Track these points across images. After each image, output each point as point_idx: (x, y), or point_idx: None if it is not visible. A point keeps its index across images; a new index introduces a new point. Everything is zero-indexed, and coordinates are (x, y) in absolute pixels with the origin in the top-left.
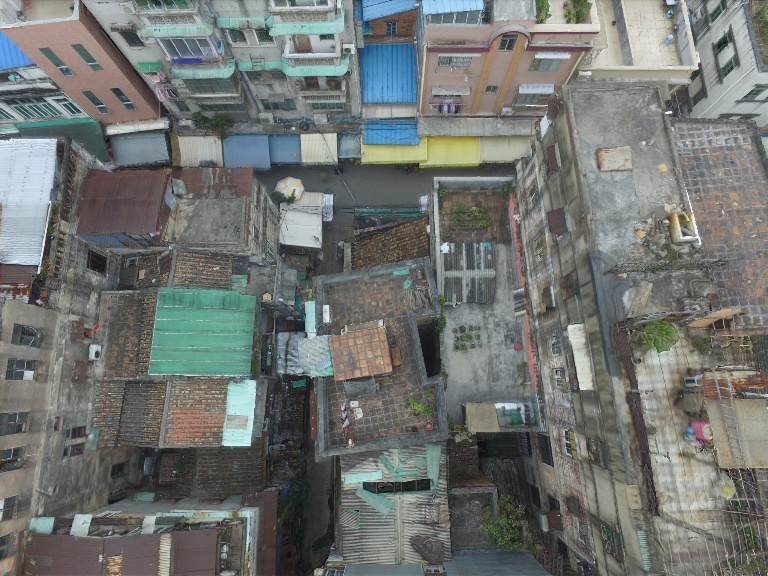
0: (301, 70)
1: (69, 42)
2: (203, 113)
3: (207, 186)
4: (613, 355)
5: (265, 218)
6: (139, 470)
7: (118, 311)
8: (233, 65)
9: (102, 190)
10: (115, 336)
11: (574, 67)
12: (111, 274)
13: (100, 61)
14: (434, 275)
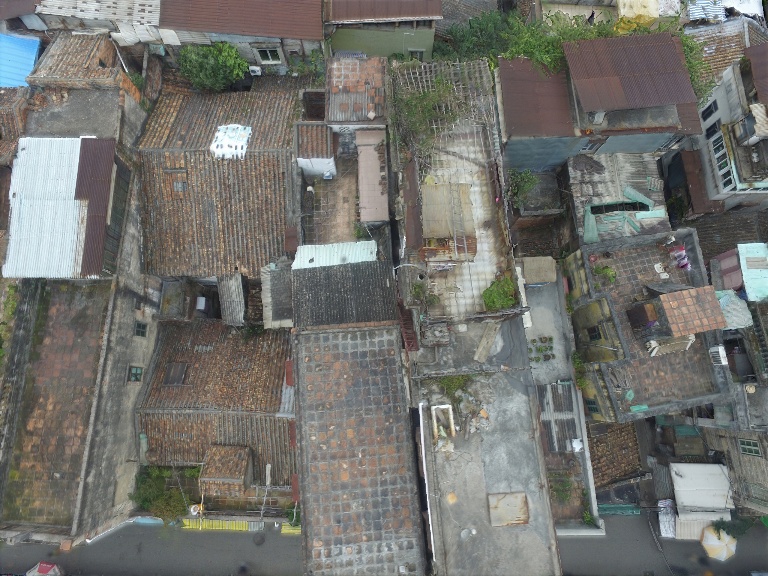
0: None
1: None
2: None
3: None
4: None
5: None
6: None
7: None
8: None
9: None
10: None
11: None
12: None
13: None
14: None
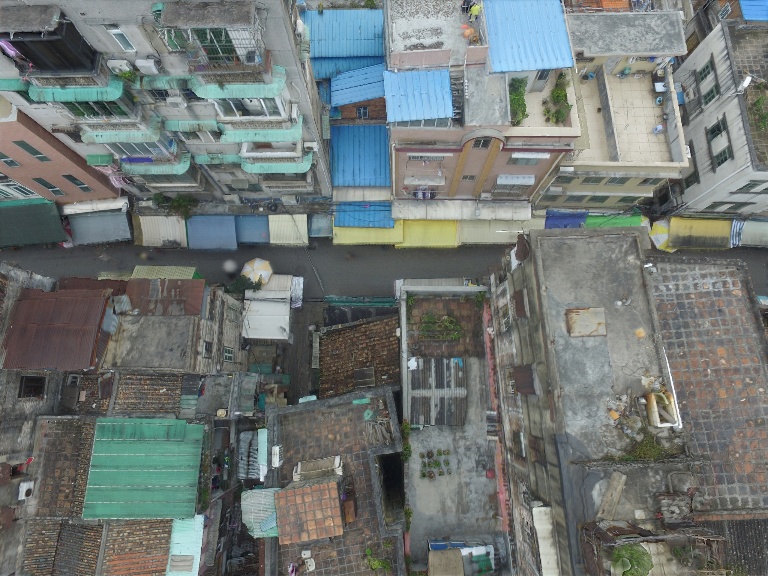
0: (260, 167)
1: (10, 139)
2: (165, 193)
3: (154, 300)
4: (579, 565)
5: (221, 324)
6: None
7: (55, 439)
8: (188, 160)
9: (34, 315)
10: (51, 468)
11: (555, 163)
12: (51, 393)
13: (47, 154)
14: (401, 392)
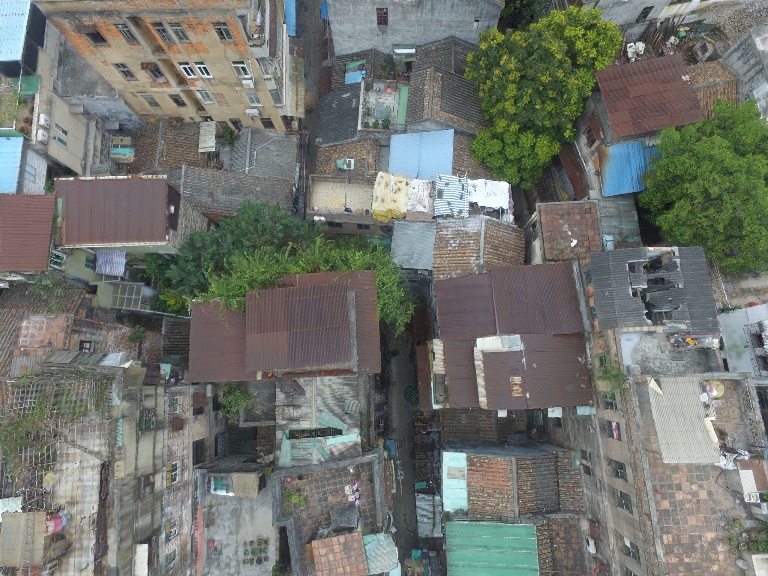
0: None
1: None
2: None
3: None
4: None
5: None
6: (546, 414)
7: None
8: None
9: None
10: (578, 558)
11: None
12: None
13: None
14: None
